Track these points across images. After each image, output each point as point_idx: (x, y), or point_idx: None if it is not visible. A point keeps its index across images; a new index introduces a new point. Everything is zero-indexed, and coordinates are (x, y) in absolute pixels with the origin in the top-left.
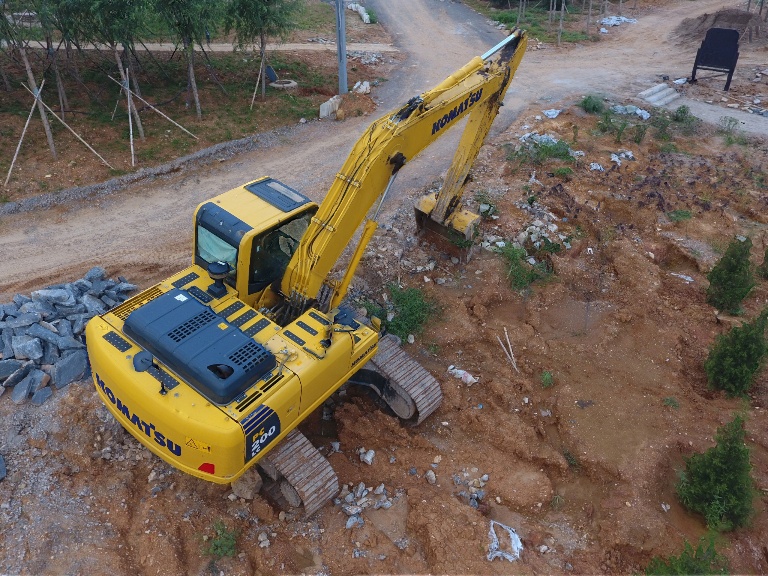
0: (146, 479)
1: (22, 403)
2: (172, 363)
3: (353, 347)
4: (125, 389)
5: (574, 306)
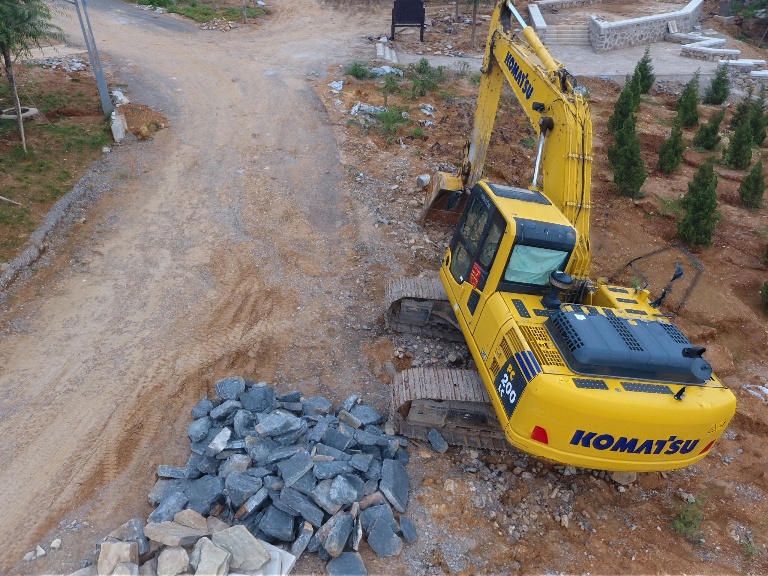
0: (561, 528)
1: (401, 550)
2: (652, 372)
3: None
4: (642, 419)
5: None
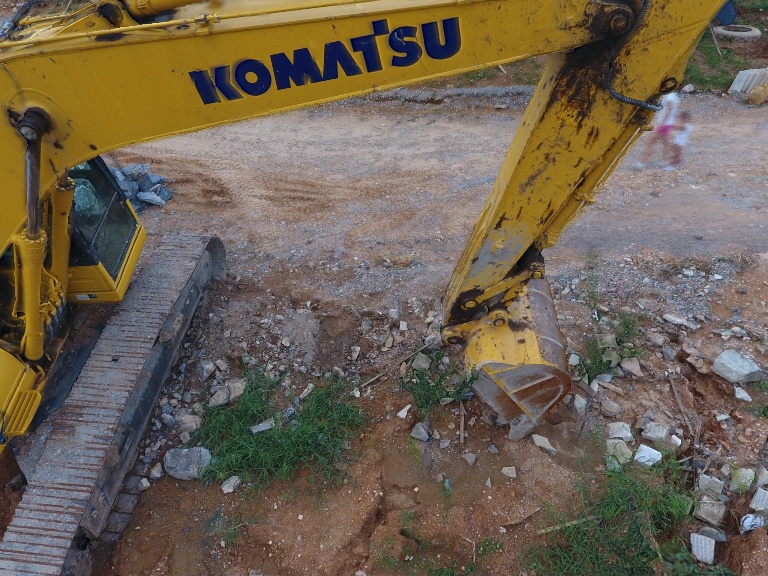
0: None
1: None
2: None
3: None
4: None
5: None
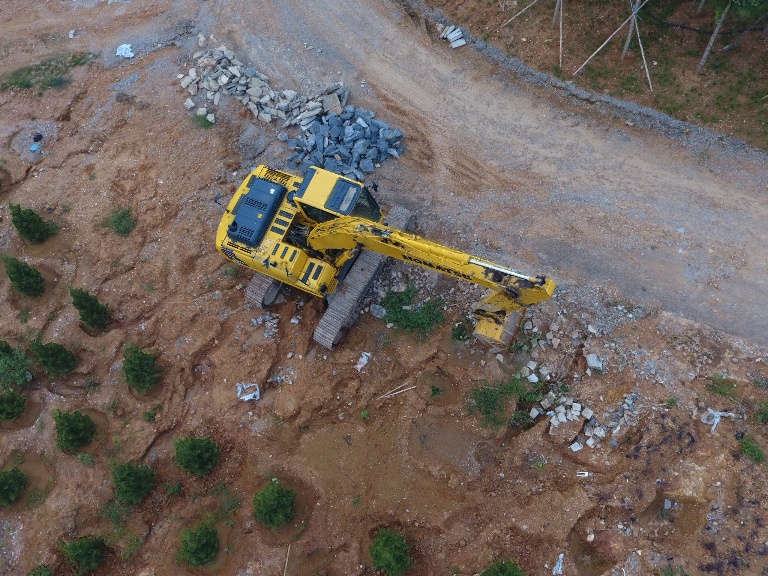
0: None
1: None
2: None
3: (291, 280)
4: None
5: (465, 443)
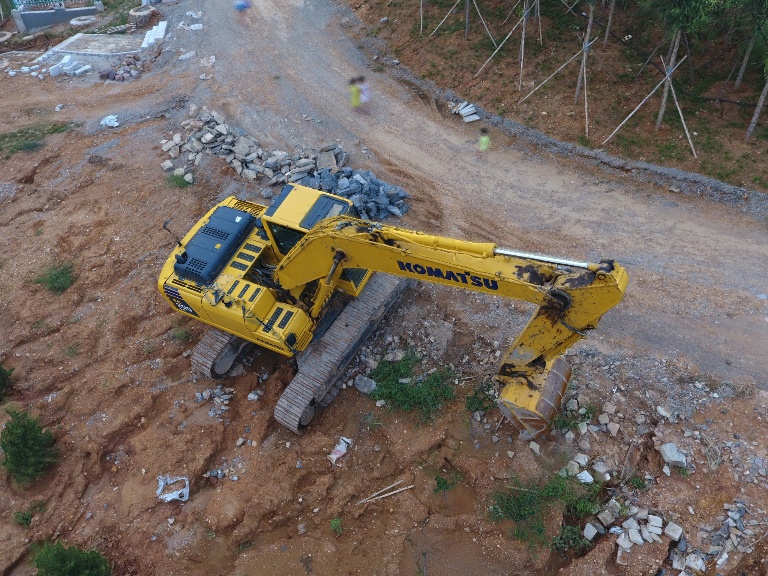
0: None
1: None
2: None
3: None
4: None
5: (486, 575)
